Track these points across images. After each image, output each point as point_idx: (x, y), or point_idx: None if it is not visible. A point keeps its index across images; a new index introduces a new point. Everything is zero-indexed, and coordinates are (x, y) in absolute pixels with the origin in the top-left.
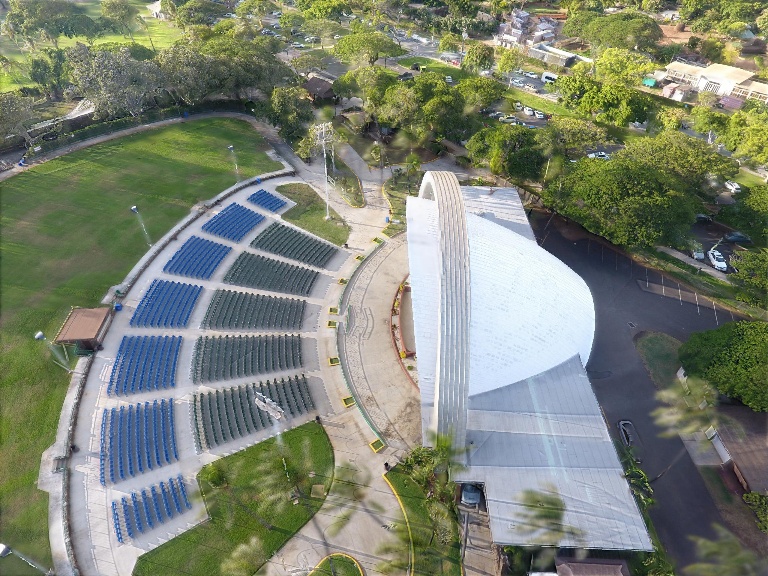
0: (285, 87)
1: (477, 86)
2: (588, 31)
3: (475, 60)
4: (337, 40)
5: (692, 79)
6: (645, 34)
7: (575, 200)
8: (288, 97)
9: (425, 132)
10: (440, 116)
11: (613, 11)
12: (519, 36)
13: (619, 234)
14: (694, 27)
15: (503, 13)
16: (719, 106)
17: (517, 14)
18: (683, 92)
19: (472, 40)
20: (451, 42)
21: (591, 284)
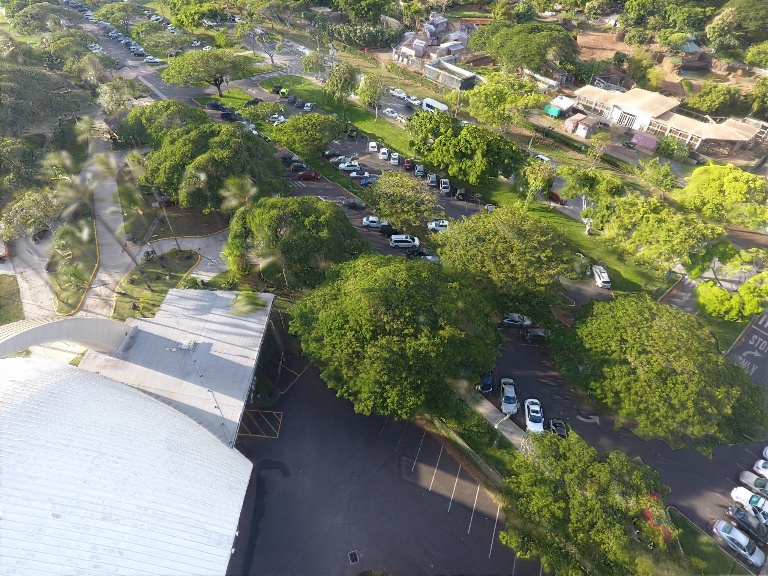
0: (96, 118)
1: (299, 127)
2: (492, 45)
3: (336, 84)
4: (175, 58)
5: (604, 108)
6: (551, 51)
7: (315, 334)
8: (3, 152)
9: (188, 201)
10: (210, 178)
11: (551, 15)
12: (421, 48)
13: (362, 396)
14: (627, 39)
15: (416, 19)
16: (629, 146)
17: (432, 20)
18: (587, 127)
19: (363, 54)
20: (313, 61)
21: (329, 465)
